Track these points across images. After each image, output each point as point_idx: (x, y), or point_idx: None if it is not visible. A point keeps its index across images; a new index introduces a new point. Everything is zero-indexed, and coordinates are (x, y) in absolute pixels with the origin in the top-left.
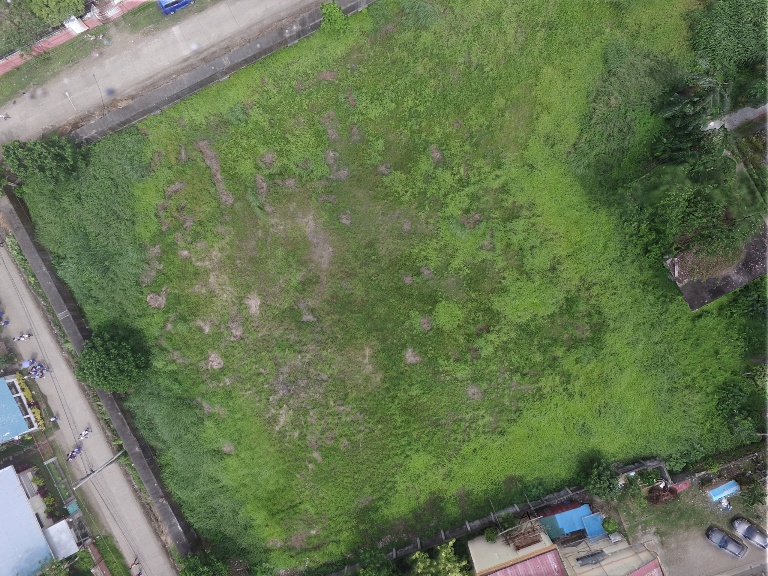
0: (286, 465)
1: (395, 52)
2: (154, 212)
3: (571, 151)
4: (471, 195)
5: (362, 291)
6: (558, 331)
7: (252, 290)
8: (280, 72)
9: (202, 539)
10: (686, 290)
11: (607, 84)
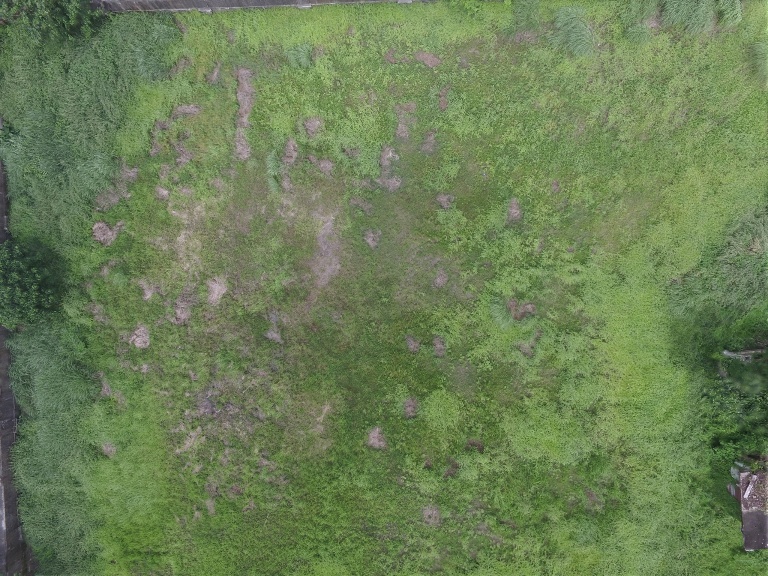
0: (168, 500)
1: (521, 67)
2: (148, 127)
3: (677, 280)
4: (535, 279)
5: (353, 334)
6: (565, 488)
7: (223, 273)
8: (374, 29)
9: (27, 543)
10: (749, 520)
11: (759, 221)
